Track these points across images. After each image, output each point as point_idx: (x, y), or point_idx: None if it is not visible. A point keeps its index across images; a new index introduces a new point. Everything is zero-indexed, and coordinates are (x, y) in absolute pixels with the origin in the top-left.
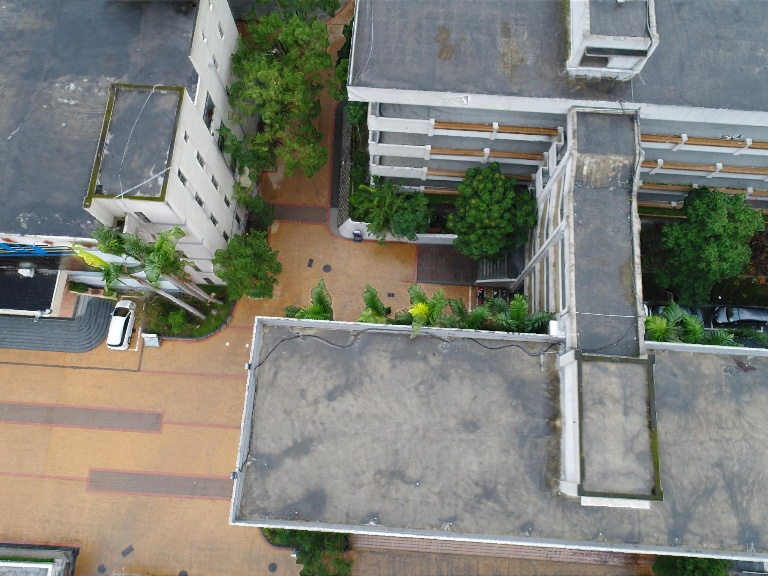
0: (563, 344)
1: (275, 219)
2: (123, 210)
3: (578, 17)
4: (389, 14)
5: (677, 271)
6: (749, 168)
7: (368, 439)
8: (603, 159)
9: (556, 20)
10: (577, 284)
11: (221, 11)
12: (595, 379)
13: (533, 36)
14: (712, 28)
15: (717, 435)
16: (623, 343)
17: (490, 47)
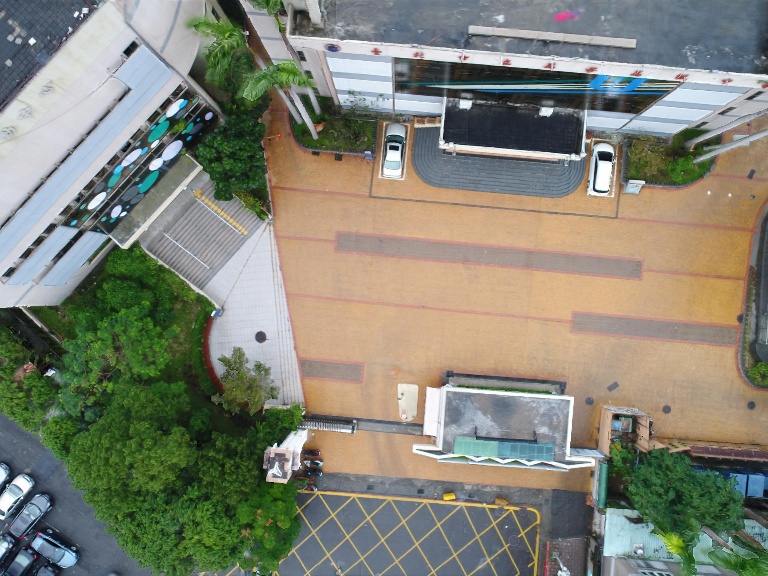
0: None
1: None
2: None
3: None
4: None
5: None
6: None
7: None
8: None
9: None
10: None
11: None
12: None
13: None
14: None
15: None
16: None
17: None
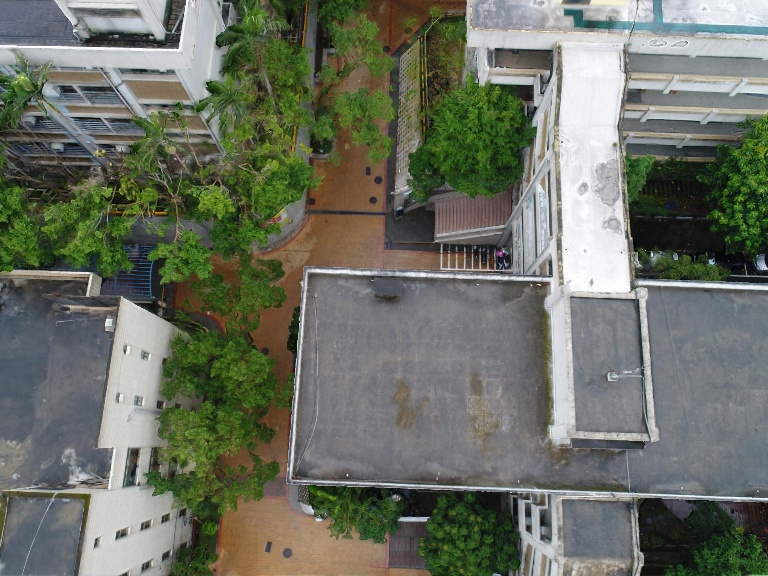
0: None
1: None
2: None
3: (561, 384)
4: (338, 366)
5: None
6: None
7: None
8: (595, 564)
9: (536, 368)
10: None
11: (144, 336)
12: None
13: (509, 391)
14: (720, 373)
15: None
16: None
17: (458, 409)
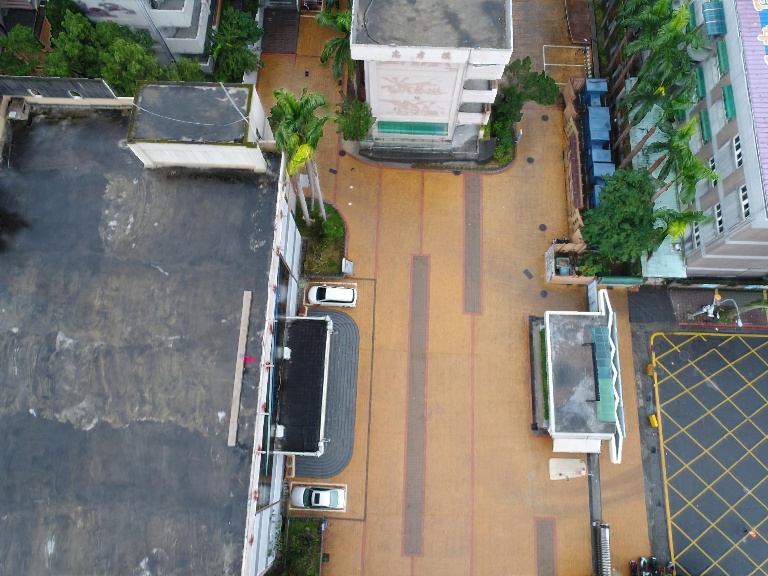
0: None
1: None
2: (255, 138)
3: None
4: None
5: None
6: None
7: None
8: None
9: None
10: None
11: None
12: None
13: None
14: None
15: None
16: None
17: None
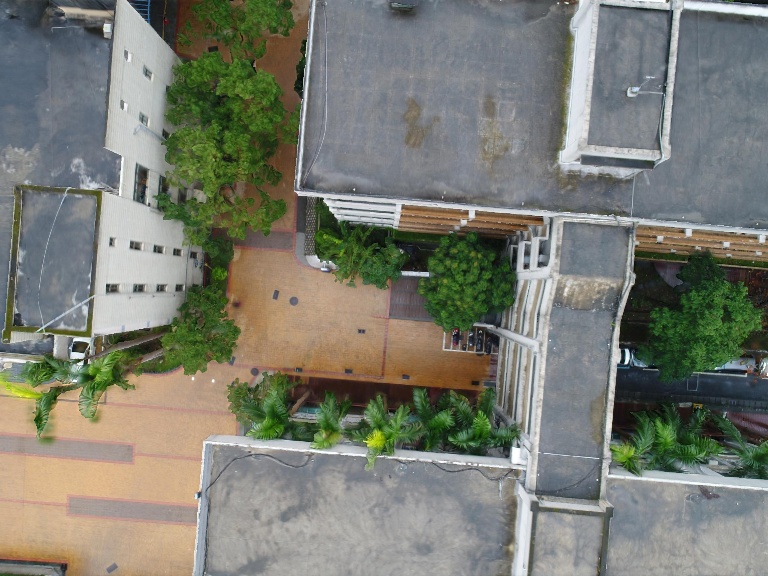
0: (524, 472)
1: (236, 245)
2: None
3: None
4: (347, 80)
5: (661, 351)
6: (760, 247)
7: (322, 559)
8: (587, 282)
9: (553, 92)
10: (543, 421)
11: (145, 50)
12: (549, 529)
13: (522, 115)
14: (743, 106)
15: (668, 562)
16: (584, 485)
17: (469, 130)
